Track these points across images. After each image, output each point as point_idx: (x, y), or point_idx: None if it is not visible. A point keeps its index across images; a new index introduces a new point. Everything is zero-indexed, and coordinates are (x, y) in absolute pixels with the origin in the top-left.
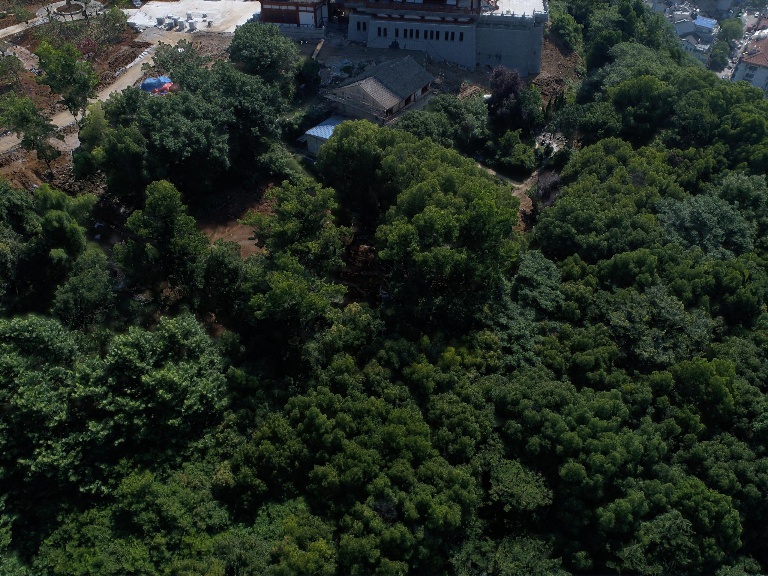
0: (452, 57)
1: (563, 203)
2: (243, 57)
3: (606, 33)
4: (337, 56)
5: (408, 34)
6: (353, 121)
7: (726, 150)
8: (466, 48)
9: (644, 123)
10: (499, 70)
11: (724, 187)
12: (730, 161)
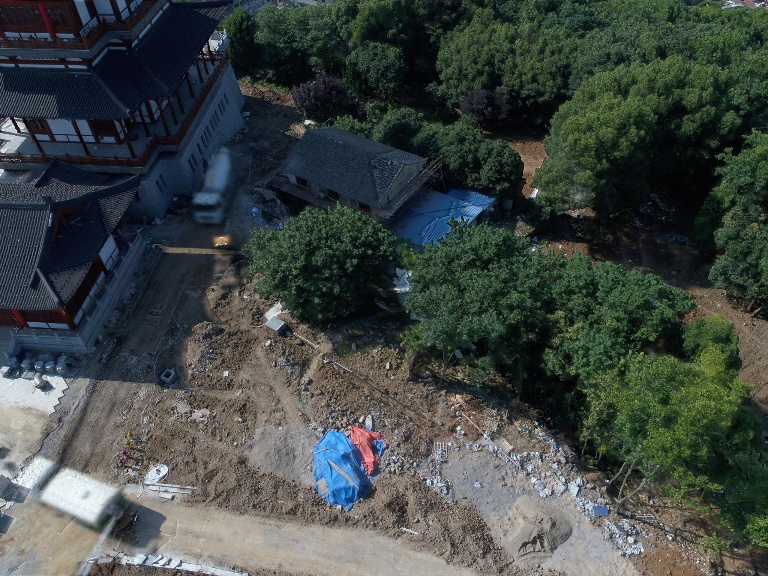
0: (232, 129)
1: (615, 51)
2: (389, 255)
3: (244, 14)
4: (225, 226)
5: (205, 140)
6: (413, 209)
7: (470, 2)
8: (232, 108)
9: (406, 33)
10: (307, 88)
11: (547, 2)
12: (477, 6)
